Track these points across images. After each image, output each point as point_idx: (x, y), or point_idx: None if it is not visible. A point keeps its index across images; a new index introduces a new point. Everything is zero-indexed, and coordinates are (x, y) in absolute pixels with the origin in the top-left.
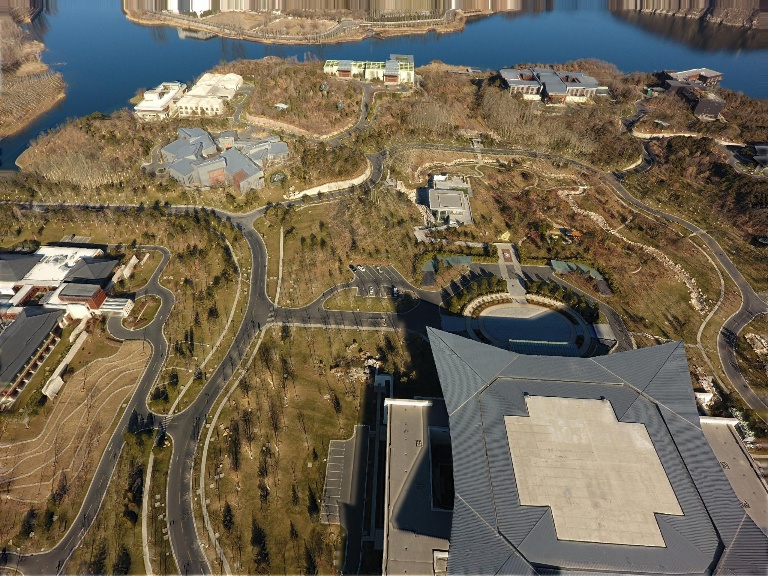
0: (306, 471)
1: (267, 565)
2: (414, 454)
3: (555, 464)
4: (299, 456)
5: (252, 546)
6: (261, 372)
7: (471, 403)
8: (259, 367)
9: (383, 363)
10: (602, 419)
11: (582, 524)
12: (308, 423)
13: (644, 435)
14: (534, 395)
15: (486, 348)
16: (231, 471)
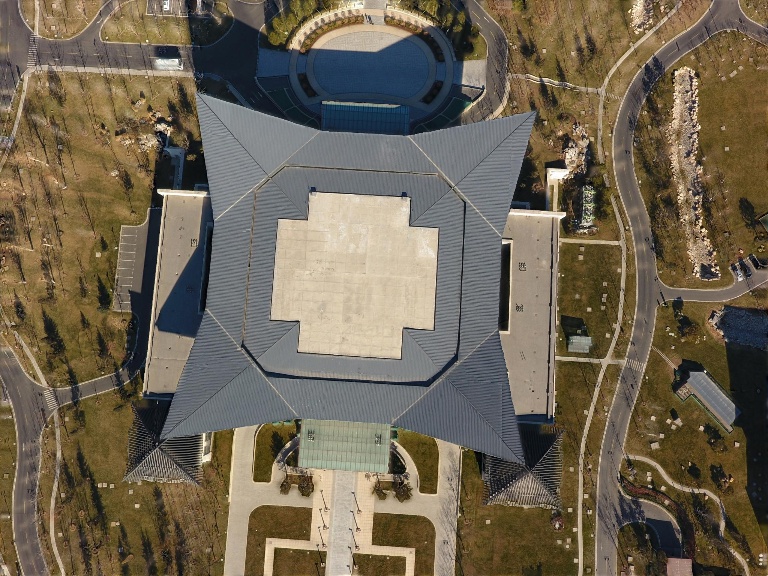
0: (94, 262)
1: (63, 349)
2: (187, 255)
3: (319, 277)
4: (85, 246)
5: (46, 334)
6: (30, 143)
7: (243, 203)
8: (27, 136)
9: (176, 128)
10: (391, 223)
11: (326, 339)
12: (92, 208)
13: (432, 243)
14: (321, 191)
15: (275, 124)
16: (14, 264)
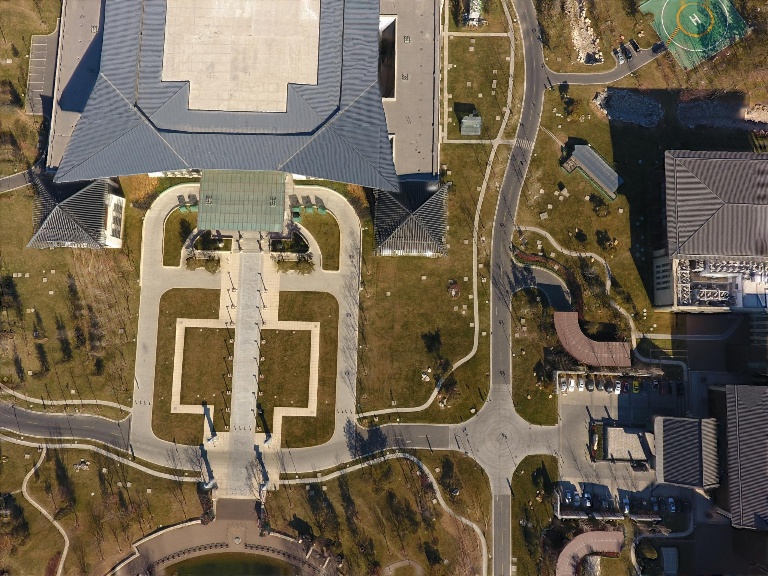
0: (5, 67)
1: None
2: (88, 40)
3: (207, 40)
4: None
5: None
6: None
7: None
8: None
9: None
10: None
11: (215, 96)
12: (2, 16)
13: (314, 6)
14: None
15: None
16: None
